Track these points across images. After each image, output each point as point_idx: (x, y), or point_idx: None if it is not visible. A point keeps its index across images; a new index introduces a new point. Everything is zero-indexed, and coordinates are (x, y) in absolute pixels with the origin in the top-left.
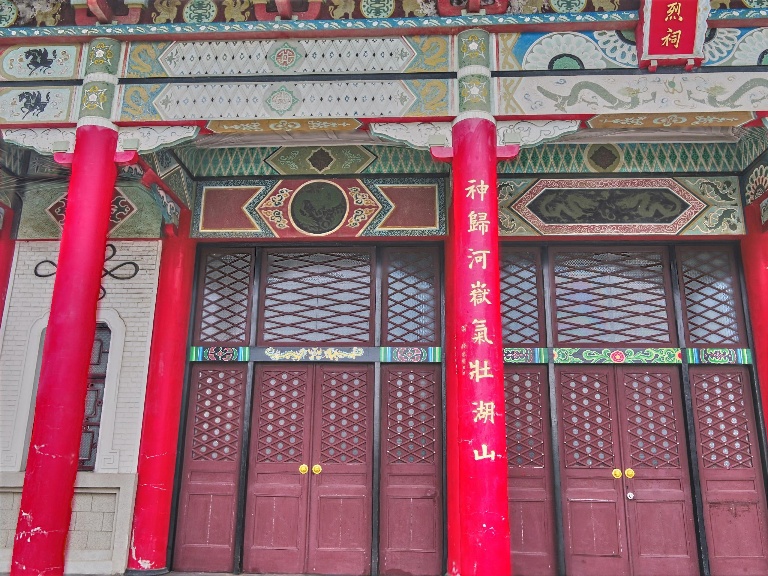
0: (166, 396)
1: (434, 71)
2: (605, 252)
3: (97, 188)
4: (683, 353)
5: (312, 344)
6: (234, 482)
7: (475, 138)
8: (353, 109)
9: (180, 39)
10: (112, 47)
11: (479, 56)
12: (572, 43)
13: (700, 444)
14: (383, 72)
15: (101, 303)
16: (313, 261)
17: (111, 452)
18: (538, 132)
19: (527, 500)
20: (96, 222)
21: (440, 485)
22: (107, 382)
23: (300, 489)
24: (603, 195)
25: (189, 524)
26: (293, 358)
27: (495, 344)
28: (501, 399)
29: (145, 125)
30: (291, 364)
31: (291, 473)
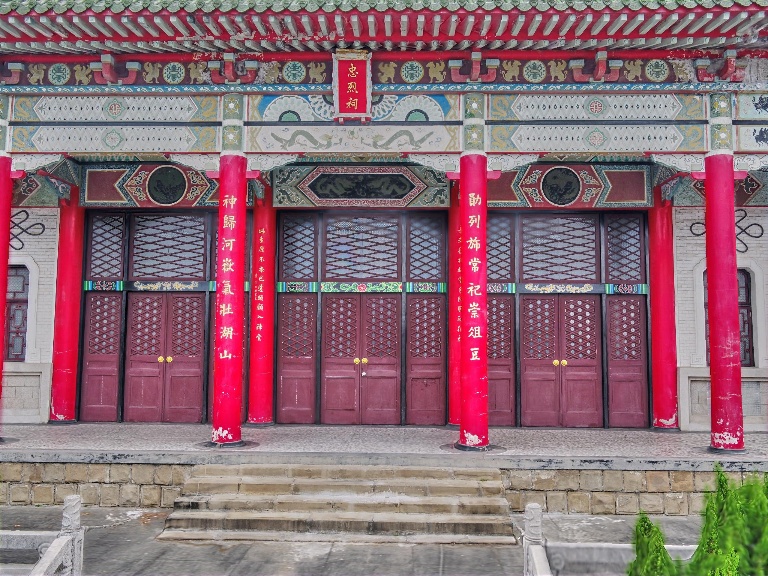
0: (68, 314)
1: (208, 121)
2: (361, 217)
3: (0, 197)
4: (403, 285)
5: (165, 279)
6: (117, 368)
7: (229, 168)
8: (157, 146)
9: (47, 95)
10: (2, 100)
11: (235, 112)
12: (295, 103)
13: (410, 343)
14: (176, 121)
15: (21, 252)
16: (165, 222)
17: (35, 350)
18: (272, 162)
19: (300, 377)
20: (1, 218)
21: (246, 369)
22: (29, 305)
23: (159, 372)
24: (359, 178)
25: (89, 393)
26: (152, 289)
27: (235, 294)
28: (238, 325)
29: (28, 153)
30: (151, 292)
31: (153, 362)
